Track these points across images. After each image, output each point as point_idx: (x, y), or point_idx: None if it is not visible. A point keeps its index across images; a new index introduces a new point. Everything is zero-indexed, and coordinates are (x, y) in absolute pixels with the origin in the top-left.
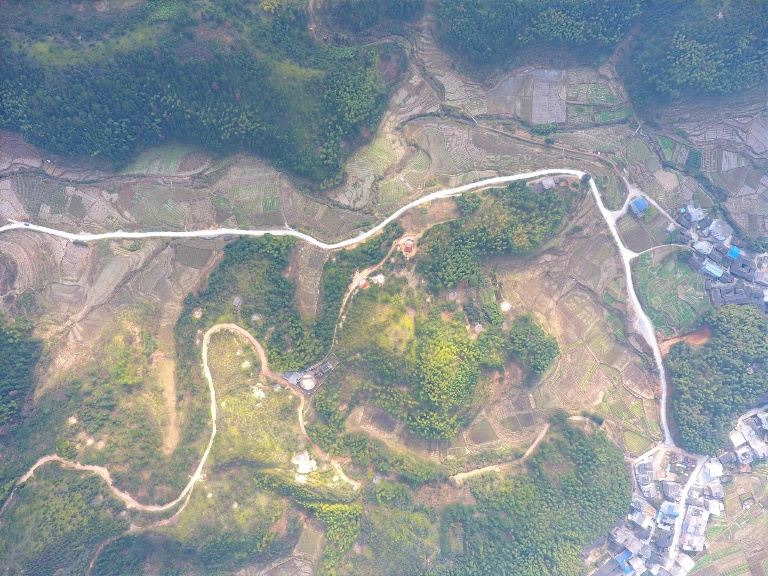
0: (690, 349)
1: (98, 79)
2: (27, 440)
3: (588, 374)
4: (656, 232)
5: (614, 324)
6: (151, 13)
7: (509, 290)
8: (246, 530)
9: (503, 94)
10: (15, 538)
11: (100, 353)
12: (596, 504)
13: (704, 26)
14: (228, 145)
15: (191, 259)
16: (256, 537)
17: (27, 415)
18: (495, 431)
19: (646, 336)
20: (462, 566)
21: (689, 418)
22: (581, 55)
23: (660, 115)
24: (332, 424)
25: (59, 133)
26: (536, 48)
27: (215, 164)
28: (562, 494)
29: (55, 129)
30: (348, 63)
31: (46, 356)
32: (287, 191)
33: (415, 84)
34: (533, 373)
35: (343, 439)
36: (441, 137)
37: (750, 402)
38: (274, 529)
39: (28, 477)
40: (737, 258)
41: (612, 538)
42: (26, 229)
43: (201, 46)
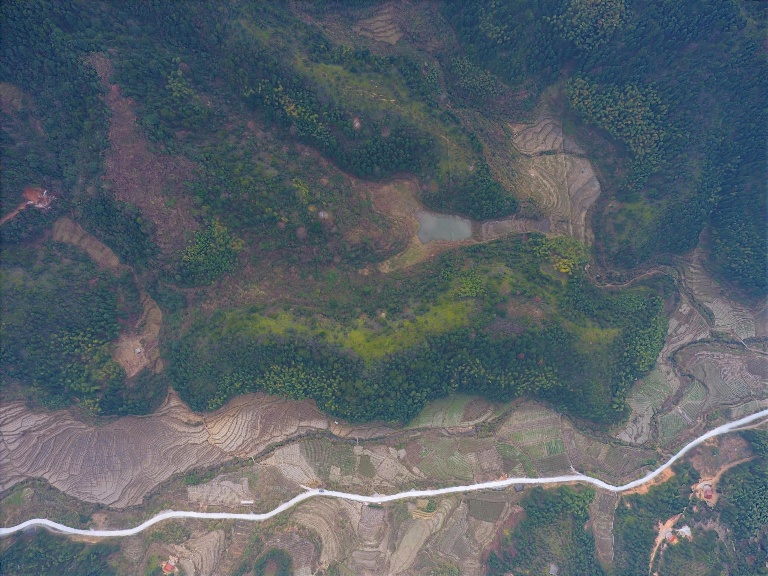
0: None
1: (412, 362)
2: None
3: None
4: None
5: None
6: (449, 282)
7: None
8: None
9: None
10: None
11: None
12: None
13: None
14: None
15: (485, 513)
16: None
17: None
18: None
19: None
20: None
21: None
22: None
23: None
24: None
25: (365, 410)
26: None
27: (497, 411)
28: None
29: None
30: (641, 315)
31: None
32: (569, 433)
33: (685, 313)
34: None
35: None
36: (716, 366)
37: None
38: None
39: None
40: None
41: None
42: (322, 496)
43: (512, 322)
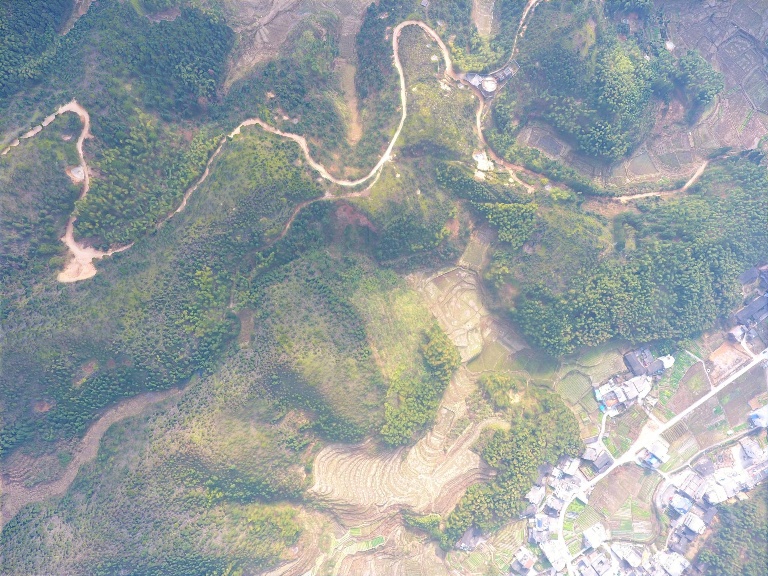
0: None
1: None
2: (226, 112)
3: (745, 119)
4: None
5: None
6: None
7: (673, 31)
8: (427, 218)
9: None
10: (230, 175)
11: (291, 45)
12: (763, 218)
13: None
14: None
15: None
16: (435, 228)
17: (222, 96)
18: (655, 164)
19: None
20: (637, 259)
21: None
22: None
23: None
24: (507, 133)
25: None
26: None
27: None
28: (731, 205)
29: None
30: None
31: (236, 50)
32: None
33: None
34: (697, 106)
35: None
36: None
37: None
38: (448, 228)
39: None
40: None
41: (764, 275)
42: None
43: None
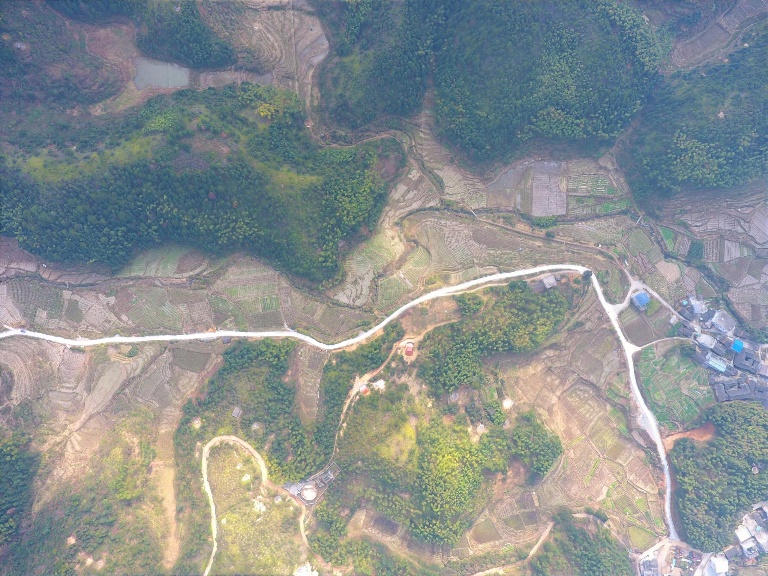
0: (694, 447)
1: (93, 192)
2: (25, 561)
3: (591, 469)
4: (658, 325)
5: (617, 419)
6: (146, 121)
7: (511, 387)
8: None
9: (503, 187)
10: None
11: (98, 466)
12: None
13: (705, 126)
14: (226, 247)
15: (189, 363)
16: None
17: (25, 532)
18: (498, 531)
19: (650, 431)
20: None
21: (694, 518)
22: (581, 148)
23: (661, 207)
24: (334, 532)
25: (55, 244)
26: (536, 142)
27: (213, 264)
28: None
29: (50, 241)
30: (346, 166)
31: (44, 469)
32: (286, 290)
33: (414, 179)
34: (536, 473)
35: (345, 547)
36: (441, 233)
37: (755, 502)
38: None
39: None
40: (740, 351)
41: None
42: (22, 336)
43: (197, 158)
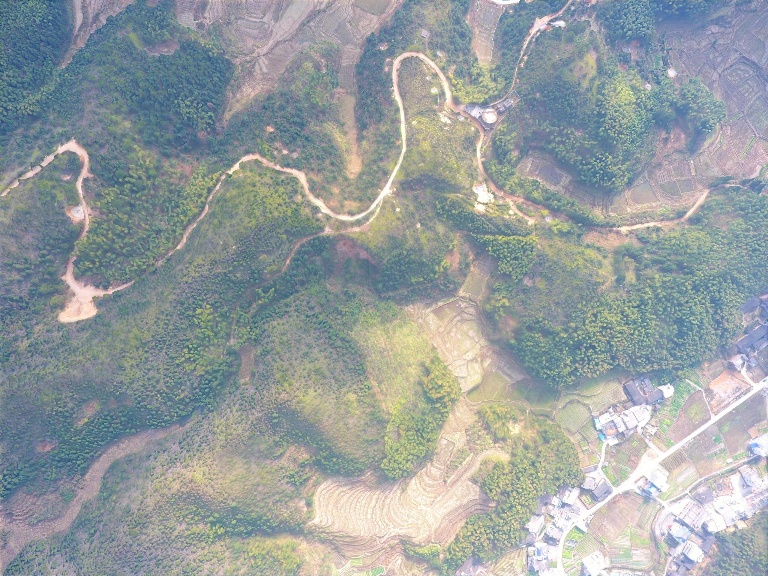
0: None
1: None
2: (225, 147)
3: (747, 147)
4: None
5: None
6: None
7: (675, 58)
8: (427, 252)
9: None
10: (229, 214)
11: (291, 77)
12: (764, 250)
13: None
14: None
15: (371, 5)
16: (435, 261)
17: (221, 129)
18: (656, 193)
19: None
20: (637, 293)
21: None
22: None
23: None
24: (507, 164)
25: None
26: None
27: None
28: None
29: None
30: None
31: (236, 81)
32: None
33: None
34: (699, 135)
35: (517, 179)
36: None
37: None
38: (448, 260)
39: (232, 172)
40: None
41: (764, 304)
42: None
43: None
